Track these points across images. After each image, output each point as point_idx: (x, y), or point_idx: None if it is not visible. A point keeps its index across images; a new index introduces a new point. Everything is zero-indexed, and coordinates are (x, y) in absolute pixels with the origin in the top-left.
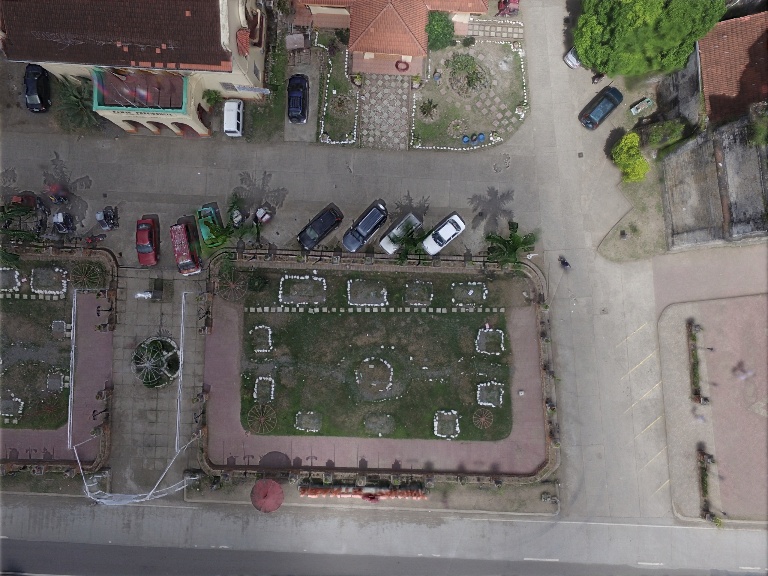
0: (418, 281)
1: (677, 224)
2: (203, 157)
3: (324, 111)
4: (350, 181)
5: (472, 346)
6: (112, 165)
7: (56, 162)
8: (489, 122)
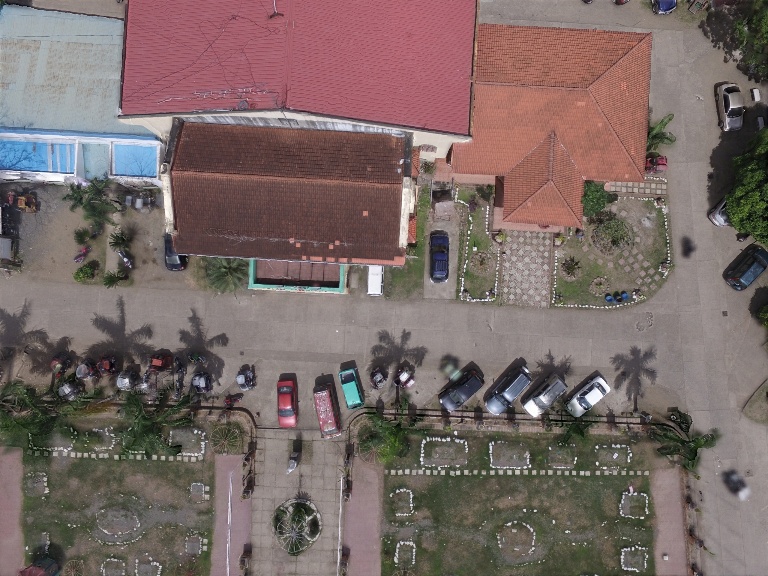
0: (561, 443)
1: None
2: (341, 314)
3: (464, 268)
4: (490, 339)
5: (616, 509)
6: (249, 322)
7: (193, 319)
8: (632, 280)
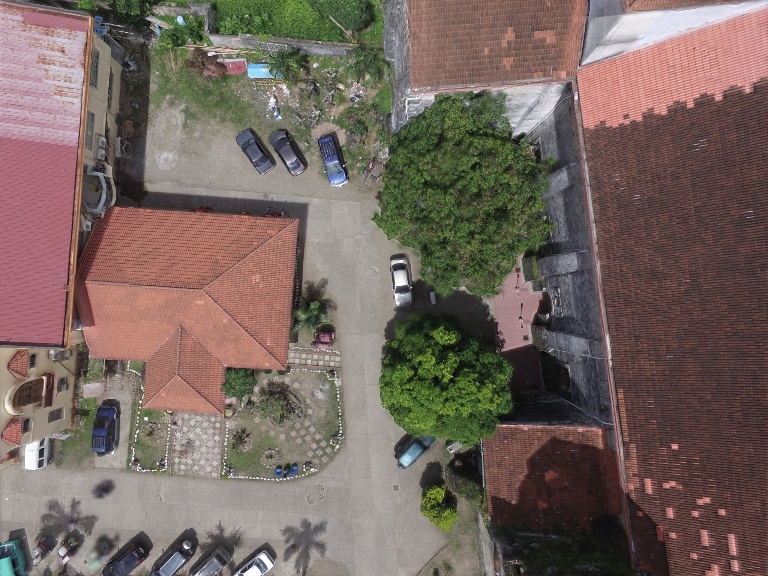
0: None
1: (486, 573)
2: (12, 482)
3: (135, 438)
4: (160, 510)
5: None
6: None
7: None
8: (303, 452)
